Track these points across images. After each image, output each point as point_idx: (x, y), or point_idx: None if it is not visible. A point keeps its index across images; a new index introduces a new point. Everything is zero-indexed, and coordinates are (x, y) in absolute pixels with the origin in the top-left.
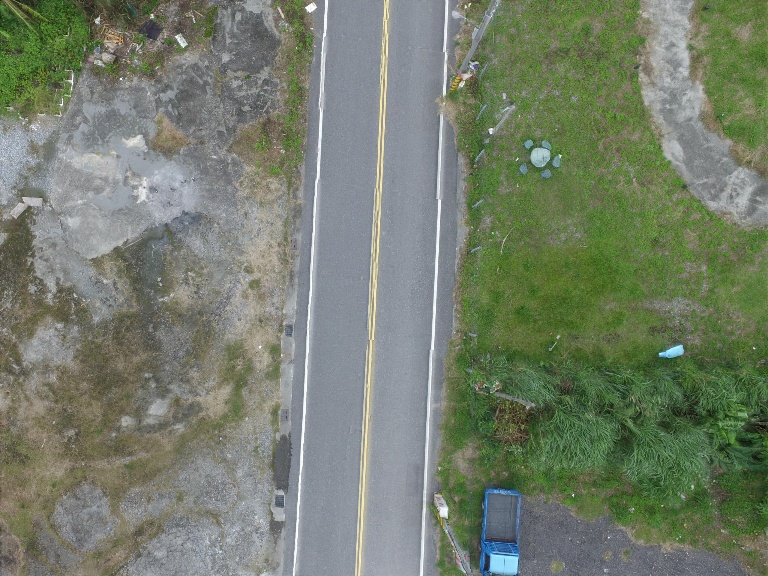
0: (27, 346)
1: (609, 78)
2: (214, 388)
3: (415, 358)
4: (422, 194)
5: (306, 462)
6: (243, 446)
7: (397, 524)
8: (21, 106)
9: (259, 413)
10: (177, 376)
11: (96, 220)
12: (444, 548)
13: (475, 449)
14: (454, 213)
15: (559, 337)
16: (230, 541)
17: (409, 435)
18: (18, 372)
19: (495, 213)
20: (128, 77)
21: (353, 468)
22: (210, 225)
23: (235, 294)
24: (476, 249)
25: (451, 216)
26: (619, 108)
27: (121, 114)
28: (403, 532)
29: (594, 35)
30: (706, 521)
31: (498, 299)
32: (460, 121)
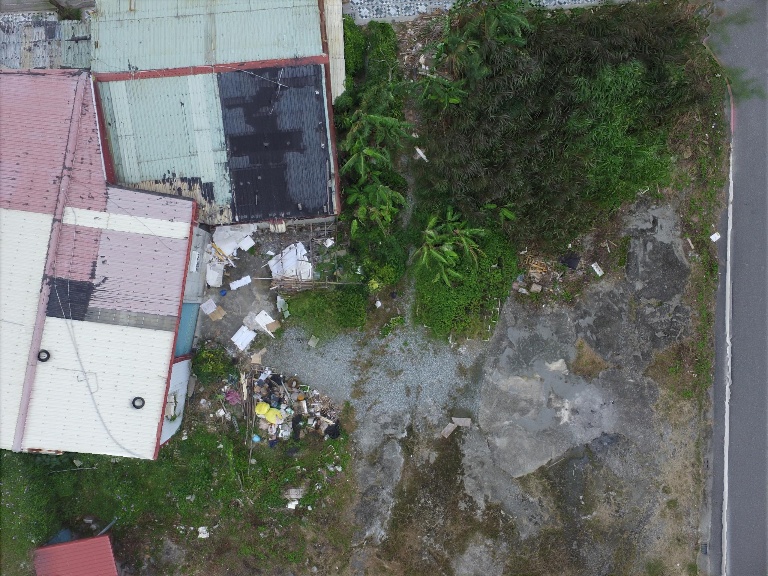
0: (459, 562)
1: None
2: None
3: None
4: None
5: None
6: None
7: None
8: (456, 334)
9: None
10: None
11: (522, 440)
12: None
13: None
14: None
15: None
16: None
17: None
18: None
19: None
20: (550, 304)
21: None
22: (628, 445)
23: (654, 513)
24: None
25: None
26: None
27: (543, 339)
28: None
29: None
30: None
31: None
32: None
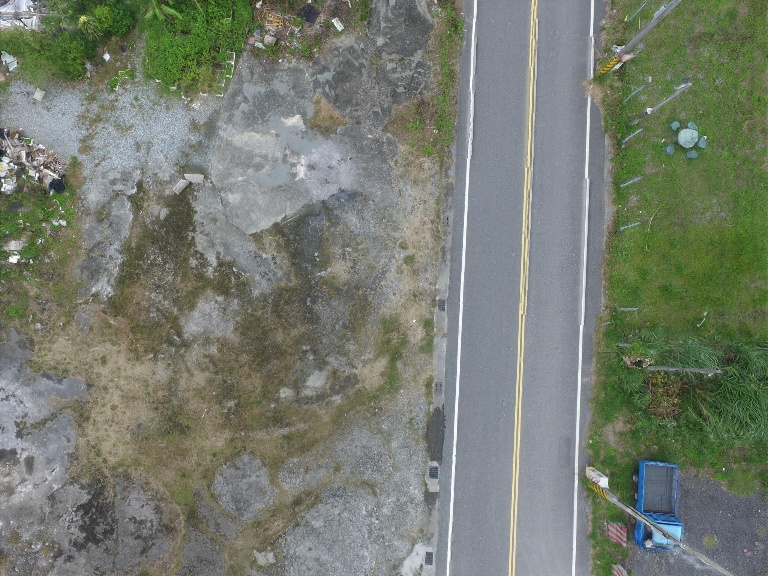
0: (188, 318)
1: (752, 62)
2: (370, 361)
3: (566, 333)
4: (571, 173)
5: (460, 434)
6: (398, 418)
7: (550, 496)
8: (186, 86)
9: (414, 386)
10: (334, 349)
11: (255, 196)
12: (597, 520)
13: (626, 423)
14: (602, 192)
15: (706, 313)
16: (386, 511)
17: (561, 408)
18: (179, 343)
19: (642, 192)
20: (287, 59)
21: (507, 440)
22: (365, 202)
23: (390, 269)
24: None
25: (599, 195)
26: (762, 91)
27: (280, 94)
28: (556, 504)
29: (737, 21)
30: None
31: (646, 276)
32: (607, 103)
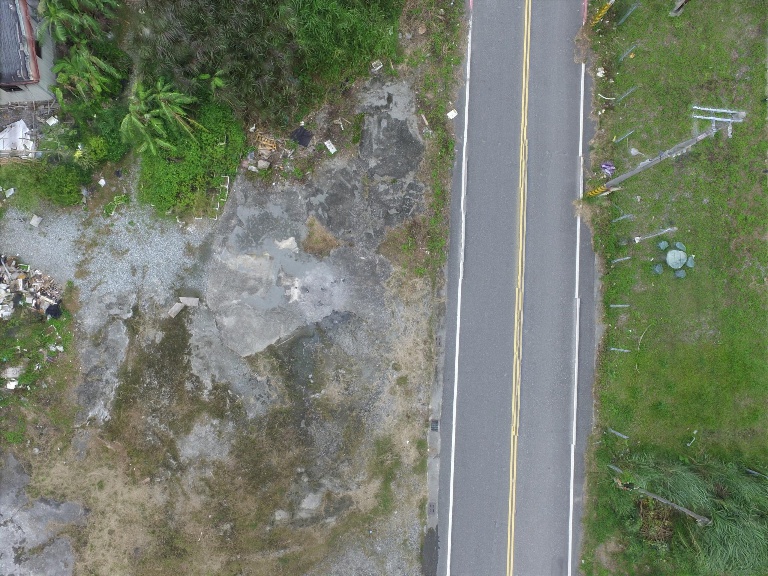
0: (184, 441)
1: (739, 181)
2: (364, 482)
3: (557, 453)
4: (562, 293)
5: (454, 555)
6: (392, 539)
7: None
8: (181, 211)
9: (407, 507)
10: (328, 471)
11: (250, 319)
12: None
13: (617, 542)
14: (592, 311)
15: (696, 432)
16: None
17: (553, 528)
18: (175, 467)
19: (632, 311)
20: (280, 182)
21: (500, 561)
22: (359, 323)
23: (383, 390)
24: (619, 350)
25: (589, 314)
26: (749, 210)
27: (274, 217)
28: None
29: (723, 140)
30: None
31: (636, 395)
32: (596, 223)
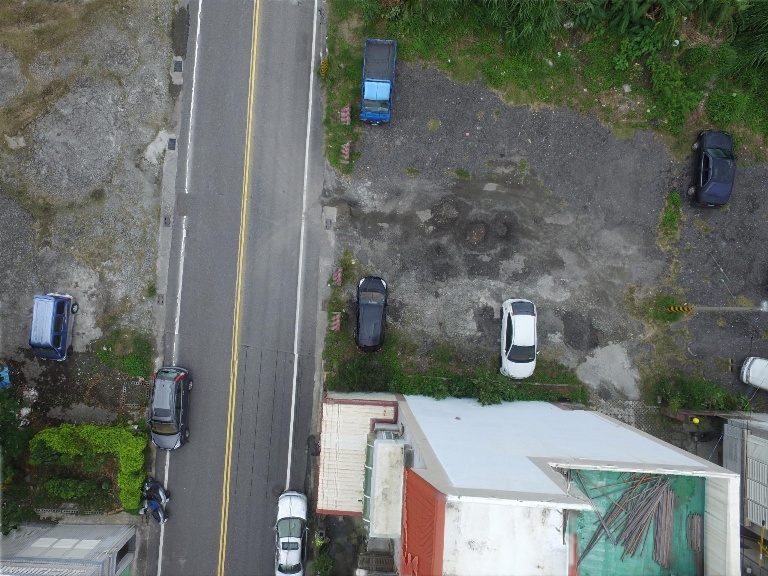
0: None
1: None
2: None
3: None
4: None
5: (203, 31)
6: (144, 15)
7: (286, 86)
8: None
9: None
10: None
11: None
12: (330, 108)
13: (360, 20)
14: None
15: None
16: (131, 100)
17: (299, 7)
18: None
19: None
20: None
21: (246, 35)
22: None
23: None
24: None
25: None
26: None
27: None
28: (292, 94)
29: None
30: (570, 81)
31: None
32: None
